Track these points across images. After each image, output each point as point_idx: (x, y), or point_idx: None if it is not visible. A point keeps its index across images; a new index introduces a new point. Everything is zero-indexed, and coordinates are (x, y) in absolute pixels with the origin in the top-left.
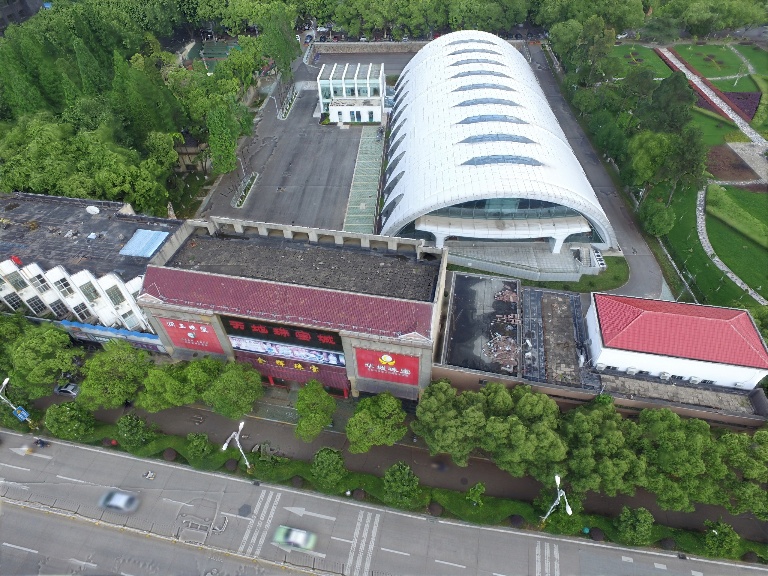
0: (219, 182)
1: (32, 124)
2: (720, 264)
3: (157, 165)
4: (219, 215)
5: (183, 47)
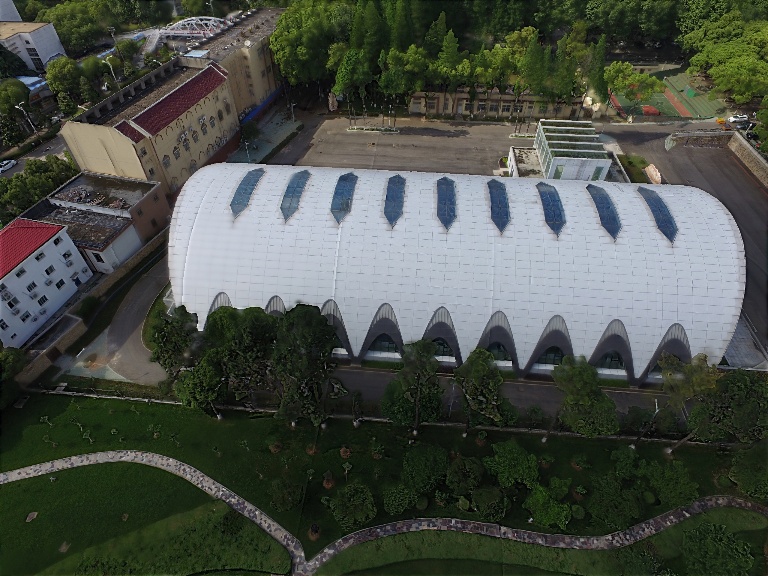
0: (388, 119)
1: (323, 4)
2: (115, 457)
3: (307, 55)
4: (340, 123)
5: (656, 62)
